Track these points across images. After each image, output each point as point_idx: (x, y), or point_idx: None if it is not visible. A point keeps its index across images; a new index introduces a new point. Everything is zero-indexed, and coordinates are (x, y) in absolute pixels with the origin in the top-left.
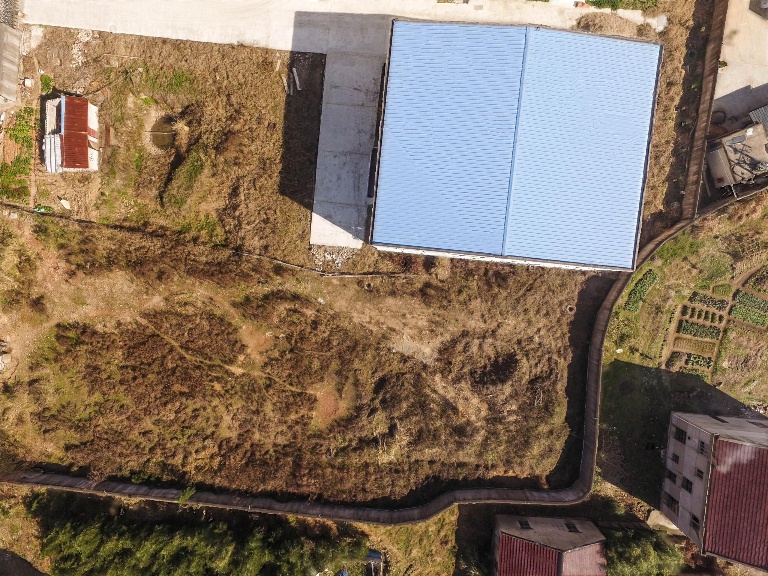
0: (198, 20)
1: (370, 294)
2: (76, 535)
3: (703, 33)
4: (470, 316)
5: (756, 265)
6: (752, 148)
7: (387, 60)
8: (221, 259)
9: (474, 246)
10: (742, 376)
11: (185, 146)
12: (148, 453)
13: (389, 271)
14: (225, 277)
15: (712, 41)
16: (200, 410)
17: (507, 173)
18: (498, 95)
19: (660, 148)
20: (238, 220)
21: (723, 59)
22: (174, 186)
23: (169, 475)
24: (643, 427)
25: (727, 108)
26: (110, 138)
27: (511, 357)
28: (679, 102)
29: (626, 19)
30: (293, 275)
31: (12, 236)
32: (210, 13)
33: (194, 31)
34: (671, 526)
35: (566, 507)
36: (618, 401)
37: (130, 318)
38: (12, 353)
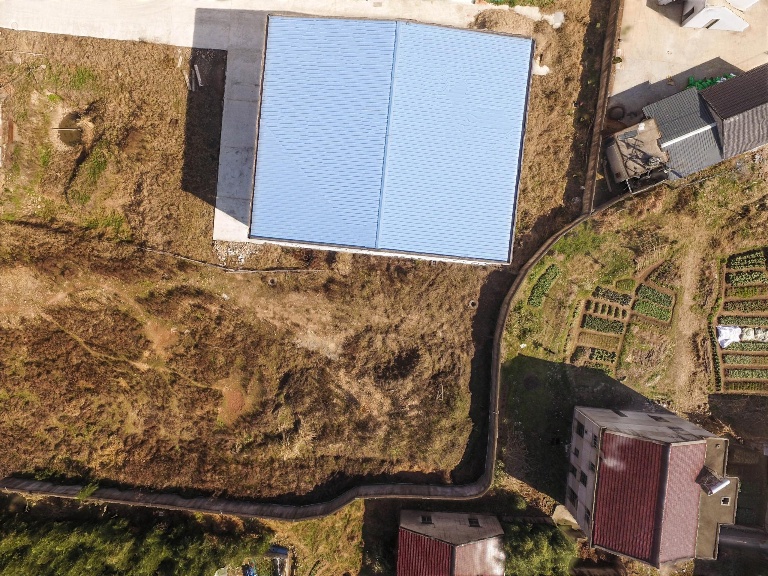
0: (99, 17)
1: (274, 289)
2: None
3: (599, 29)
4: (373, 311)
5: (658, 260)
6: (644, 143)
7: (263, 55)
8: (125, 255)
9: (348, 239)
10: (646, 370)
11: (90, 142)
12: (54, 450)
13: (292, 266)
14: (127, 273)
15: (608, 37)
16: (105, 406)
17: (380, 166)
18: (370, 89)
19: (559, 143)
20: (142, 216)
21: (621, 55)
22: (78, 182)
23: (74, 471)
24: (548, 422)
25: (626, 104)
26: (13, 134)
27: (414, 352)
28: (577, 98)
29: (523, 16)
30: (197, 271)
31: None
32: (111, 10)
33: (96, 28)
34: None
35: (471, 502)
36: (523, 396)
37: (35, 314)
38: None
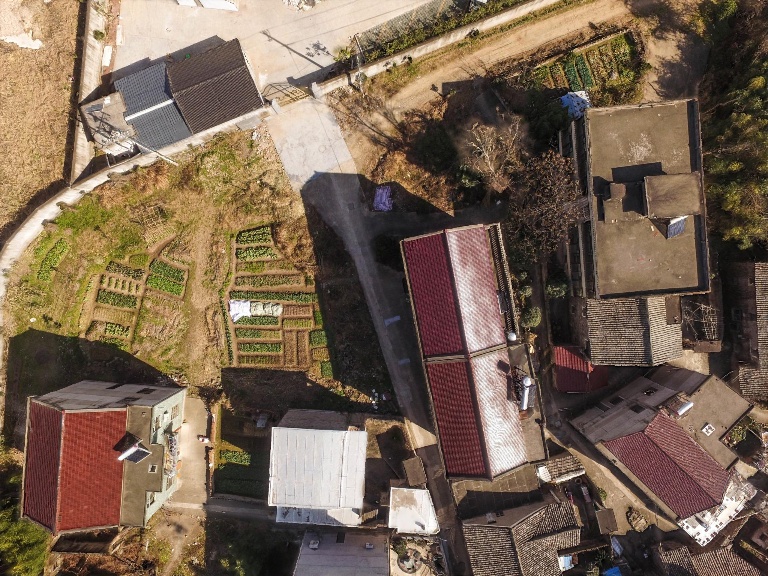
0: None
1: None
2: None
3: None
4: None
5: (169, 235)
6: (111, 116)
7: None
8: None
9: None
10: (158, 344)
11: None
12: None
13: None
14: None
15: None
16: None
17: None
18: None
19: (52, 117)
20: None
21: (122, 31)
22: None
23: None
24: None
25: None
26: None
27: None
28: (73, 72)
29: None
30: None
31: None
32: None
33: None
34: None
35: None
36: (35, 370)
37: None
38: None
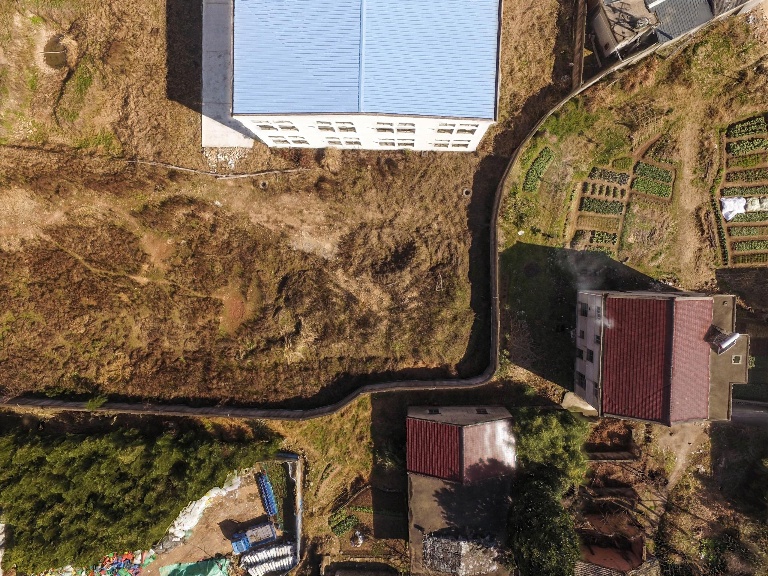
0: None
1: (266, 193)
2: None
3: None
4: (367, 207)
5: (655, 135)
6: (631, 5)
7: None
8: (117, 170)
9: (331, 106)
10: (648, 249)
11: (75, 61)
12: (62, 369)
13: (282, 168)
14: (120, 185)
15: None
16: (109, 322)
17: (357, 28)
18: None
19: (544, 19)
20: (131, 129)
21: None
22: (65, 100)
23: (83, 388)
24: (551, 308)
25: None
26: None
27: (410, 245)
28: None
29: None
30: (188, 180)
31: None
32: None
33: None
34: (586, 407)
35: (479, 395)
36: (524, 284)
37: (34, 235)
38: None
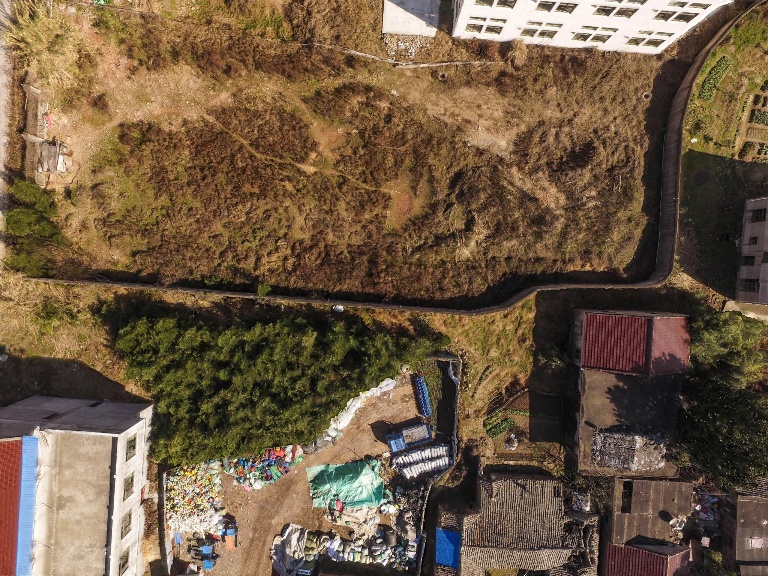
0: None
1: (444, 85)
2: (153, 326)
3: None
4: (546, 106)
5: None
6: None
7: None
8: (290, 52)
9: None
10: None
11: None
12: (218, 258)
13: (463, 60)
14: (297, 66)
15: None
16: (272, 211)
17: None
18: None
19: None
20: (307, 10)
21: None
22: None
23: (242, 278)
24: (718, 217)
25: None
26: None
27: (588, 146)
28: None
29: None
30: (365, 66)
31: (70, 29)
32: None
33: None
34: None
35: (643, 300)
36: (693, 192)
37: (197, 115)
38: (73, 156)
